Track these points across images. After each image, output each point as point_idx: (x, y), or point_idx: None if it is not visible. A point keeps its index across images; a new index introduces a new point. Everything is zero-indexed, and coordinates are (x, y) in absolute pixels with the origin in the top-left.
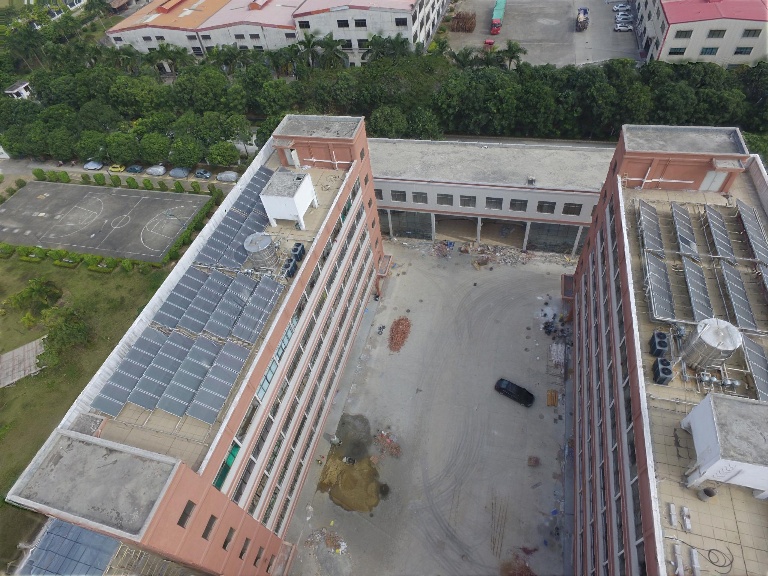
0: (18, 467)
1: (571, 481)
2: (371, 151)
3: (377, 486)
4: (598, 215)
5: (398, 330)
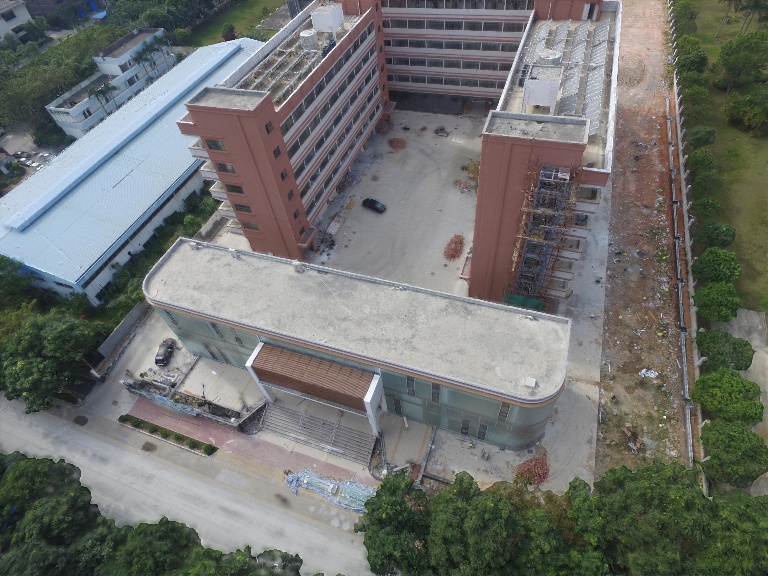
0: (744, 169)
1: (359, 172)
2: (494, 364)
3: (469, 170)
4: (282, 170)
5: (455, 244)
